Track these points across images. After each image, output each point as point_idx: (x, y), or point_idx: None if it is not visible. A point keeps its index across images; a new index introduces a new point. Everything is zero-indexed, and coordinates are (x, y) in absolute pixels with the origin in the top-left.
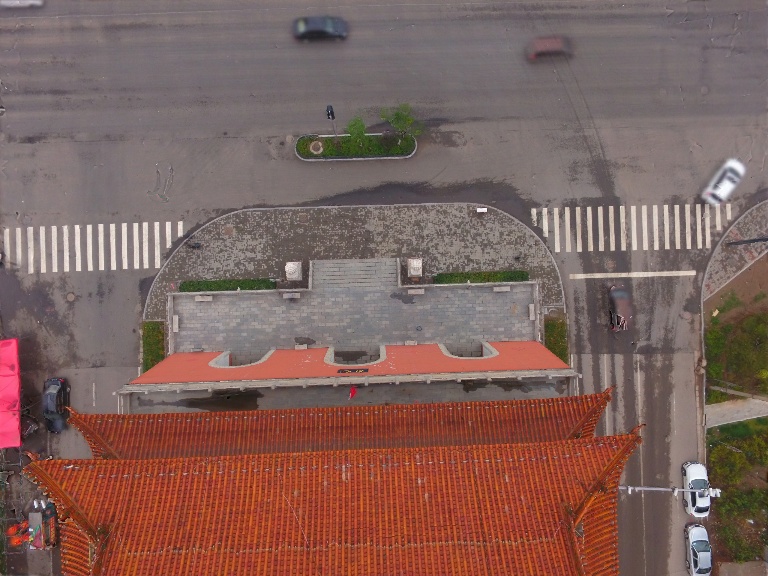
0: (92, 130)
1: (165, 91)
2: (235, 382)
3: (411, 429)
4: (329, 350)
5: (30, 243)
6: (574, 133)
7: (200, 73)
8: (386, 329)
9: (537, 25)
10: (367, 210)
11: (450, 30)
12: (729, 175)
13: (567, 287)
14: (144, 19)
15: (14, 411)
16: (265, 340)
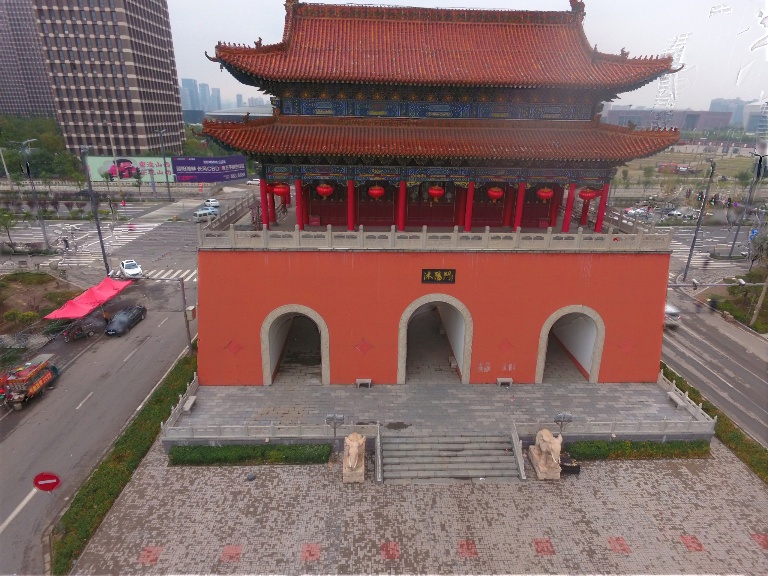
0: None
1: None
2: None
3: None
4: None
5: None
6: None
7: None
8: None
9: None
10: None
11: None
12: None
13: None
14: None
15: (96, 303)
16: None
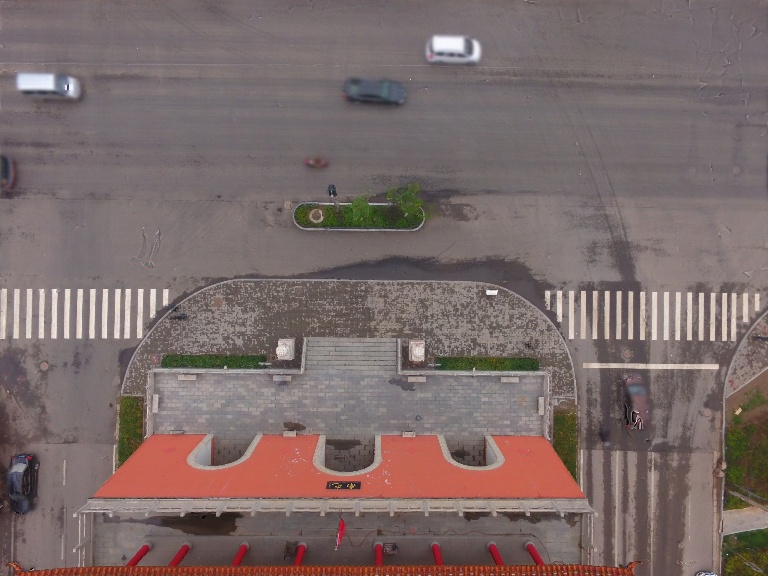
0: (75, 187)
1: (156, 148)
2: (212, 500)
3: None
4: (320, 440)
5: (3, 306)
6: (595, 211)
7: (195, 130)
8: (383, 417)
9: (560, 93)
10: (368, 285)
11: (466, 95)
12: (759, 263)
13: (580, 377)
14: (137, 70)
15: None
16: (251, 424)
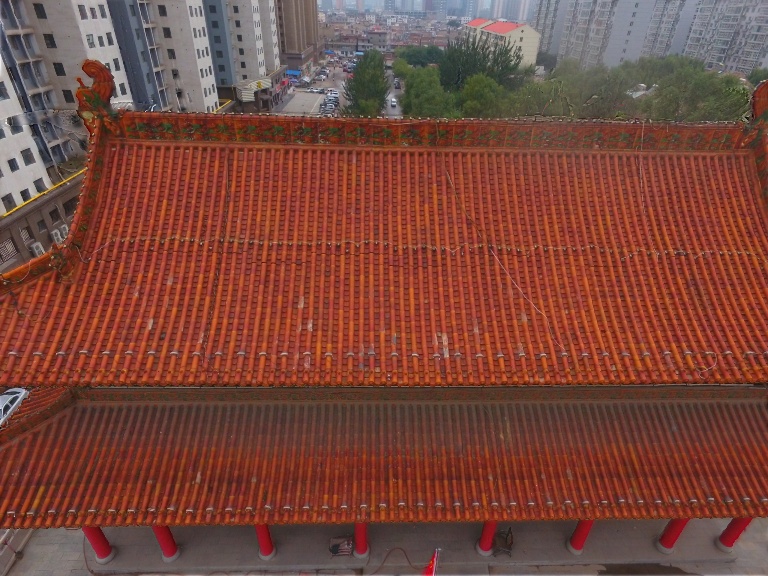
0: None
1: None
2: None
3: (316, 471)
4: None
5: None
6: None
7: None
8: None
9: None
10: None
11: None
12: None
13: None
14: None
15: None
16: None
